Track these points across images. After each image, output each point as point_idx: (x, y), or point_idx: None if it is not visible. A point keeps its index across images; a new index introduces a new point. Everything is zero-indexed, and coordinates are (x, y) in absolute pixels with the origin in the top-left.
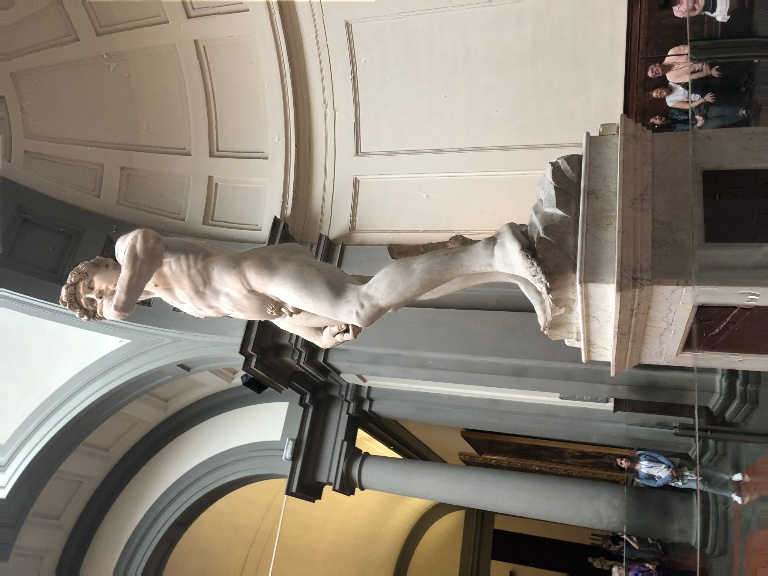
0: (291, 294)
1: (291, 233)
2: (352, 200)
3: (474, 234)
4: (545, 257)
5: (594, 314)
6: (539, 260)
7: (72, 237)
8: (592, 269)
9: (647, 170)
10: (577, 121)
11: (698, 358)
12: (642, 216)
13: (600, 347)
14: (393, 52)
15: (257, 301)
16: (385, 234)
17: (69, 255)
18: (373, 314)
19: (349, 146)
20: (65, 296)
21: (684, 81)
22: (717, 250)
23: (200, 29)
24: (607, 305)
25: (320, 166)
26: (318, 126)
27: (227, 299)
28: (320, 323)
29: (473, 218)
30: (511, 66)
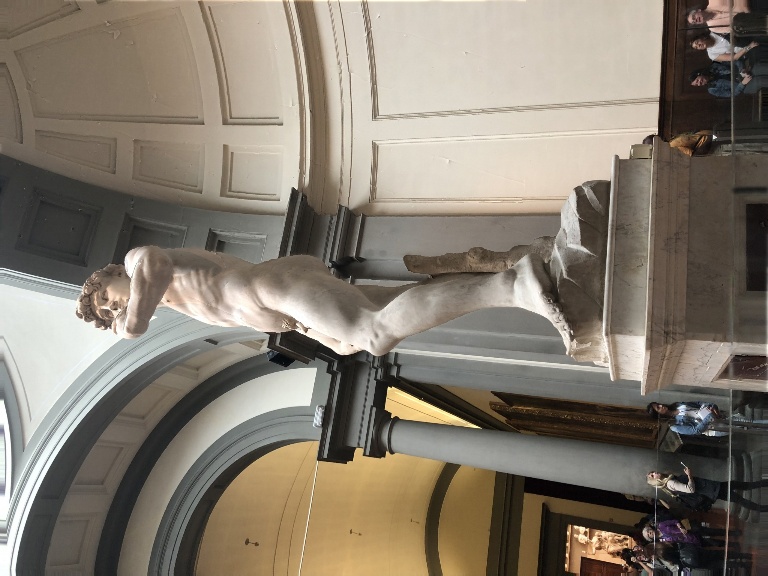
0: (304, 316)
1: (310, 204)
2: (371, 167)
3: (499, 202)
4: (568, 302)
5: (622, 352)
6: (562, 305)
7: (91, 216)
8: (620, 318)
9: (683, 203)
10: (610, 76)
11: (735, 385)
12: (676, 259)
13: (629, 371)
14: (409, 6)
15: (271, 318)
16: (407, 203)
17: (89, 235)
18: (388, 345)
19: (366, 109)
20: (80, 309)
21: (729, 32)
22: (760, 301)
23: None
24: (636, 348)
25: (337, 131)
26: (333, 89)
27: (240, 315)
28: None
29: (498, 184)
30: (537, 18)
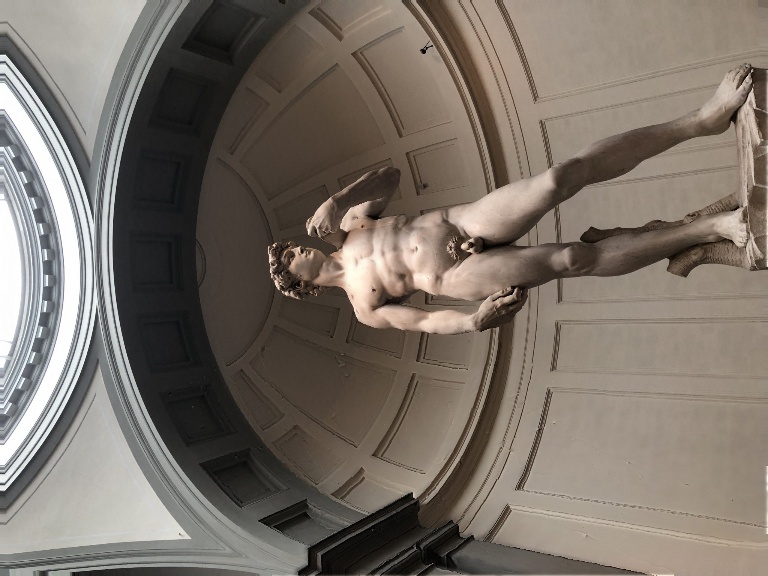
0: (488, 196)
1: (418, 518)
2: (497, 521)
3: None
4: None
5: None
6: None
7: (223, 431)
8: None
9: None
10: None
11: None
12: None
13: None
14: (585, 419)
15: (446, 229)
16: None
17: (210, 438)
18: (568, 163)
19: (513, 480)
20: None
21: None
22: None
23: (422, 369)
24: None
25: (475, 488)
26: (488, 458)
27: (418, 231)
28: (491, 267)
29: (640, 566)
30: (707, 448)
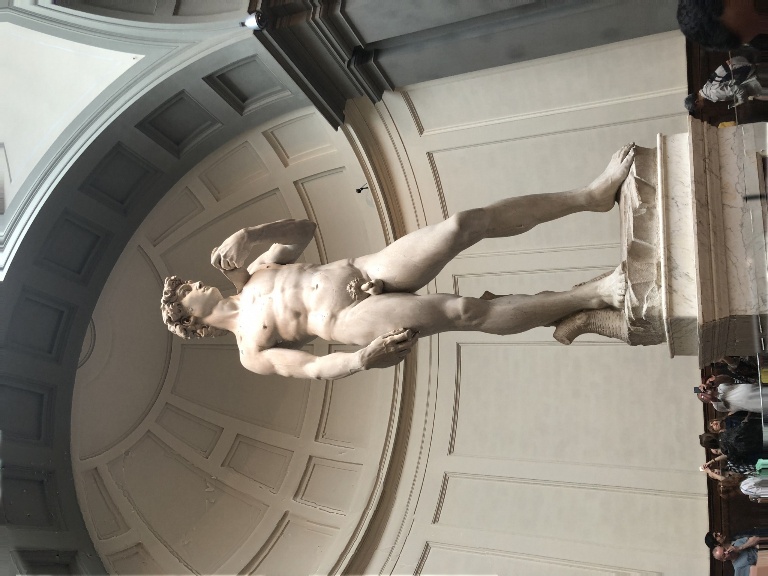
0: None
1: None
2: None
3: None
4: None
5: (673, 193)
6: None
7: (51, 526)
8: None
9: None
10: None
11: None
12: None
13: (682, 274)
14: None
15: (349, 271)
16: None
17: (33, 528)
18: (473, 210)
19: None
20: None
21: None
22: None
23: (296, 509)
24: (683, 172)
25: None
26: None
27: None
28: (387, 306)
29: None
30: None
